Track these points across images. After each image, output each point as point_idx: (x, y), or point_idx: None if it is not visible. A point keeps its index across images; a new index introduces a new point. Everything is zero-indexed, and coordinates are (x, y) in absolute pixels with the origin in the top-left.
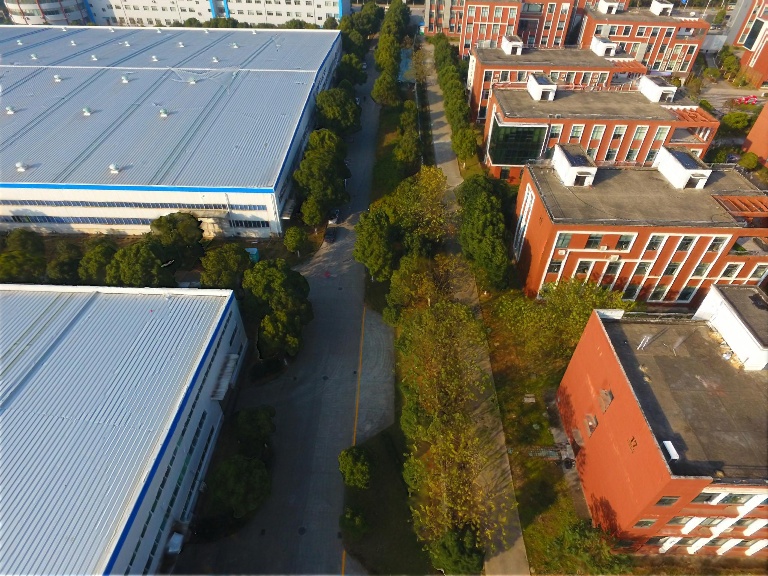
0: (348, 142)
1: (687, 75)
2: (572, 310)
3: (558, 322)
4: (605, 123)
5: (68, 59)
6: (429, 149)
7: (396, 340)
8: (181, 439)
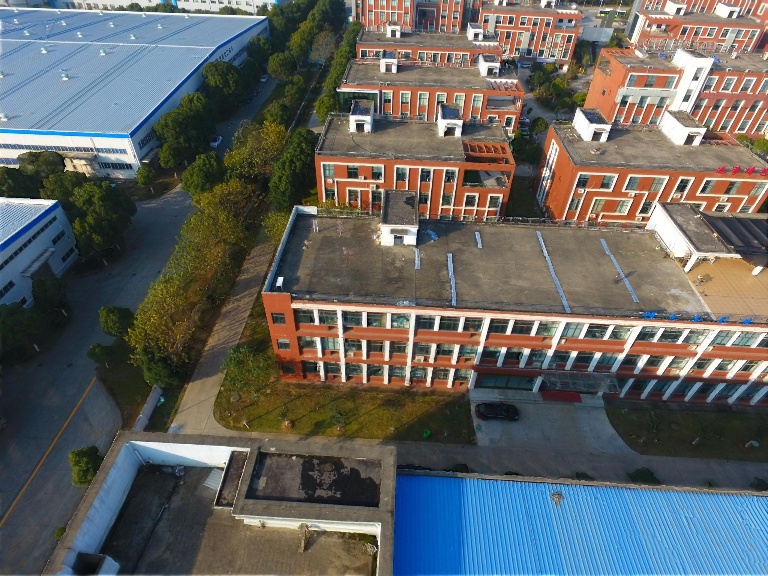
0: (240, 110)
1: (569, 62)
2: None
3: None
4: (428, 91)
5: (4, 34)
6: (306, 117)
7: None
8: None
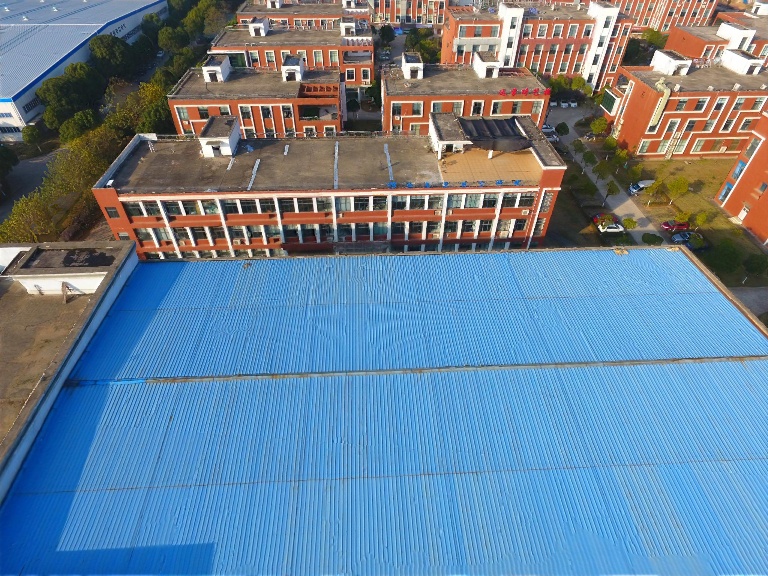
0: (133, 82)
1: None
2: None
3: None
4: (289, 49)
5: None
6: None
7: None
8: None
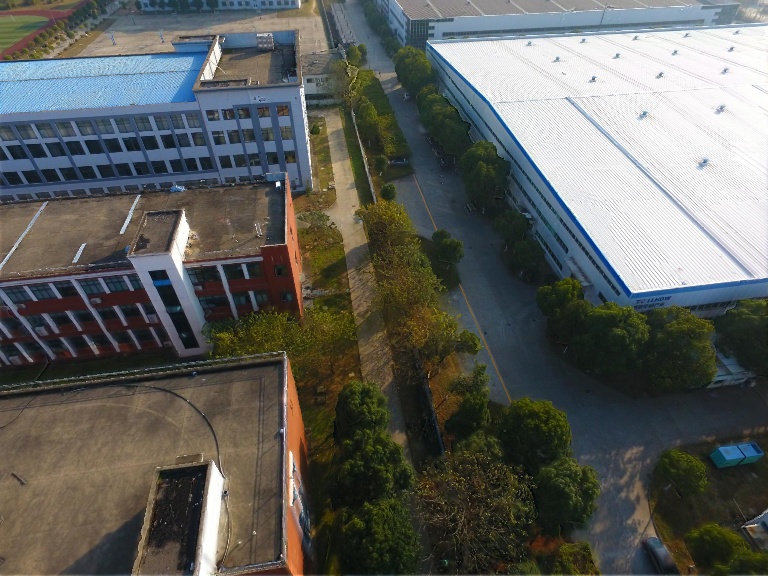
0: None
1: None
2: None
3: None
4: None
5: None
6: None
7: None
8: None
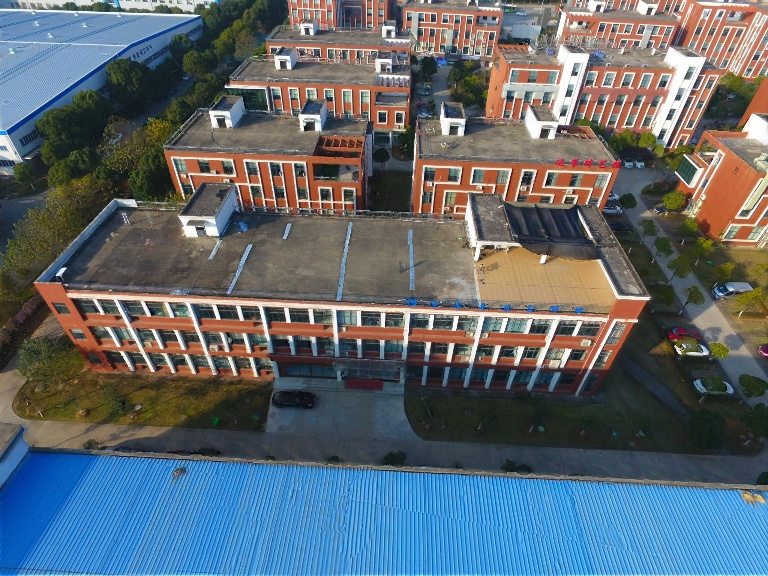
0: (152, 108)
1: None
2: None
3: None
4: (315, 87)
5: None
6: None
7: None
8: None
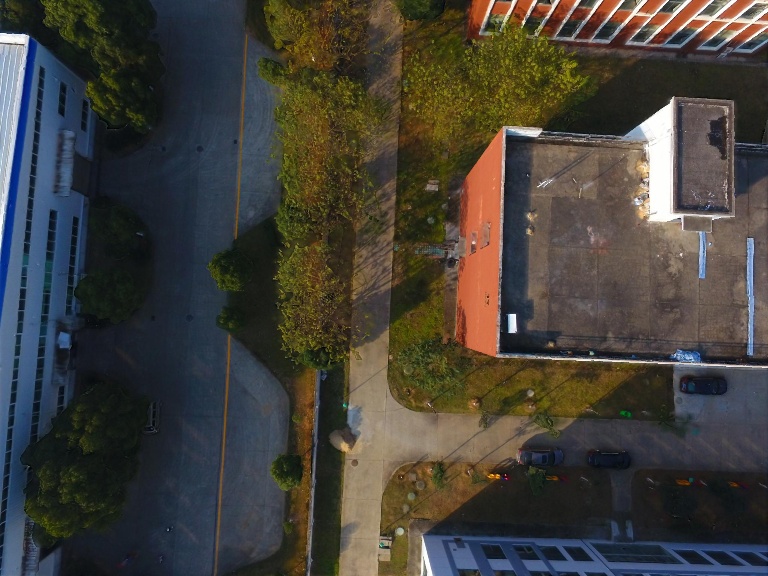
0: None
1: None
2: (501, 86)
3: (478, 103)
4: None
5: None
6: None
7: (276, 110)
8: (27, 257)
